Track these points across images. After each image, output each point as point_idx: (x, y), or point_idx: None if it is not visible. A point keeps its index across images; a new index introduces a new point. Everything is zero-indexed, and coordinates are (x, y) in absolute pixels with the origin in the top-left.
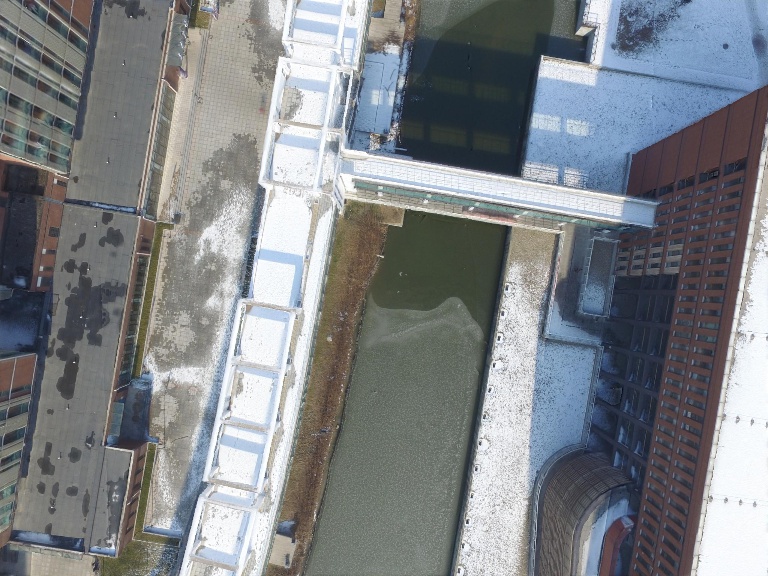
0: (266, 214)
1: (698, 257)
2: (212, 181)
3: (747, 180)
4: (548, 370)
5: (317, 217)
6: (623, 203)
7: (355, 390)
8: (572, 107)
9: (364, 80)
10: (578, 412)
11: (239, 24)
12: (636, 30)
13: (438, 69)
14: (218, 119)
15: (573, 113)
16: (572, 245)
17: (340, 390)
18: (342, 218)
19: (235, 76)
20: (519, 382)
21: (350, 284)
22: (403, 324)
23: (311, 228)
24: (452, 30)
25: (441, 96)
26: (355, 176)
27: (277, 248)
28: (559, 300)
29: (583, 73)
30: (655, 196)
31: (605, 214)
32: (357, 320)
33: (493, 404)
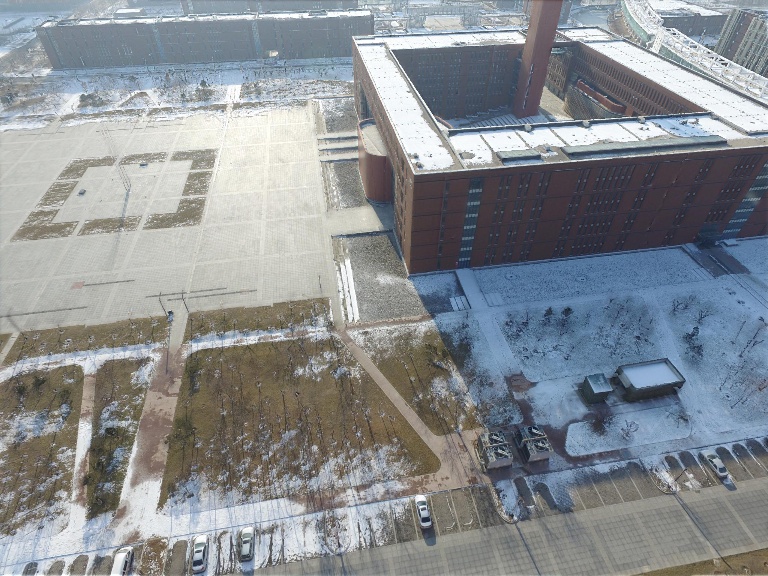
0: None
1: None
2: None
3: None
4: None
5: None
6: None
7: None
8: None
9: None
10: None
11: None
12: None
13: None
14: None
15: None
16: None
17: None
18: None
19: None
20: None
21: None
22: None
23: None
24: None
25: None
26: None
27: None
28: None
29: None
30: None
31: None
32: None
33: None
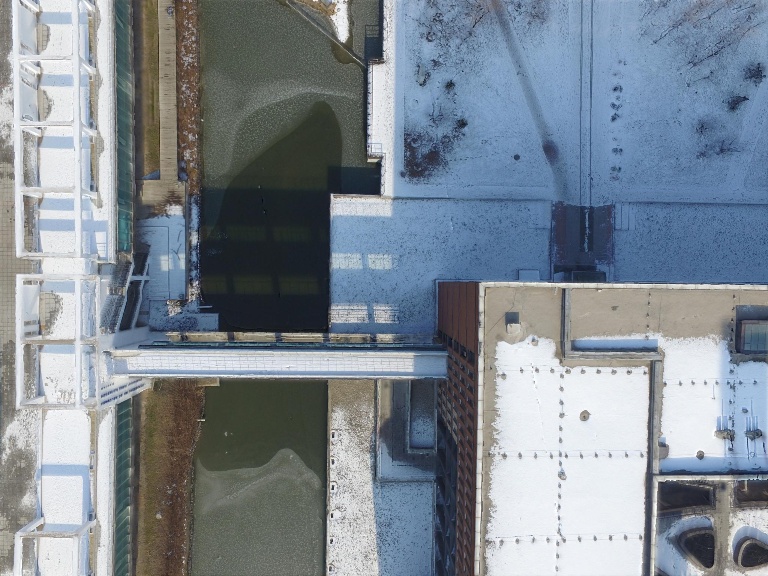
0: (42, 428)
1: (462, 439)
2: (7, 376)
3: (475, 380)
4: (387, 511)
5: (97, 423)
6: (413, 358)
7: (197, 559)
8: (371, 241)
9: (150, 247)
10: (424, 548)
11: (8, 208)
12: (422, 155)
13: (232, 218)
14: (2, 310)
15: (373, 247)
16: (391, 383)
17: (181, 563)
18: (151, 391)
19: (13, 263)
20: (360, 528)
21: (172, 455)
22: (236, 484)
23: (91, 436)
24: (239, 176)
25: (239, 246)
26: (130, 374)
27: (60, 461)
28: (386, 441)
29: (377, 205)
30: (446, 343)
31: (396, 372)
32: (188, 488)
33: (337, 555)
